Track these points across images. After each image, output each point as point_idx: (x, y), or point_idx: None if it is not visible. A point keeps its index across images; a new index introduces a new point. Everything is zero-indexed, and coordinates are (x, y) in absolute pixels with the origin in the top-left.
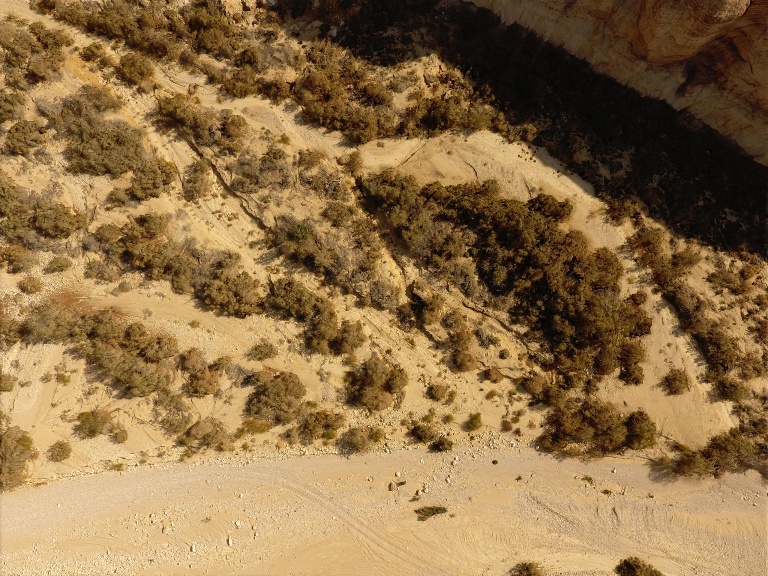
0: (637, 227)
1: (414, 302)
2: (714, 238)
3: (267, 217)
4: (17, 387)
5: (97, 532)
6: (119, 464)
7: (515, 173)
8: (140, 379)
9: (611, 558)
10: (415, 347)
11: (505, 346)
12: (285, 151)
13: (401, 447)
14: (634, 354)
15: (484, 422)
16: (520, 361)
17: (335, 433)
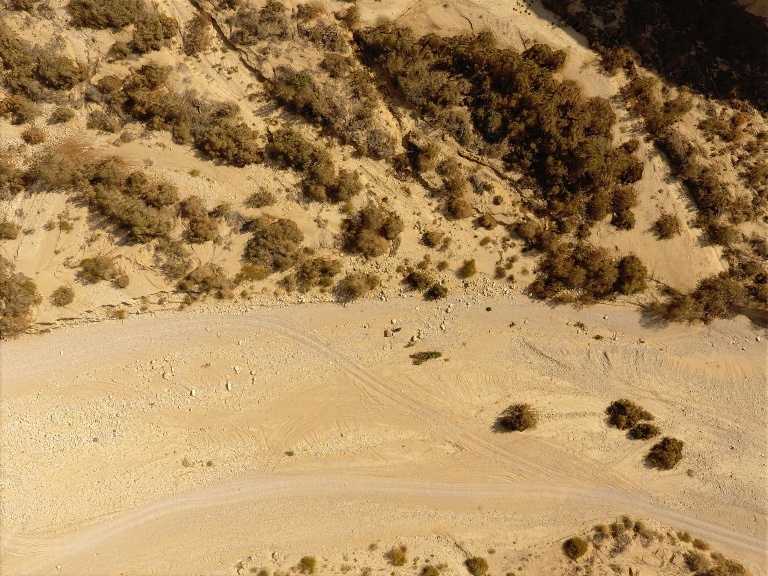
0: (630, 77)
1: (410, 151)
2: (706, 86)
3: (266, 68)
4: (21, 235)
5: (99, 378)
6: (121, 310)
7: (510, 25)
8: (141, 219)
9: (602, 400)
10: (411, 195)
11: (499, 193)
12: (284, 4)
13: (397, 295)
14: (626, 199)
15: (478, 269)
16: (514, 207)
17: (332, 280)
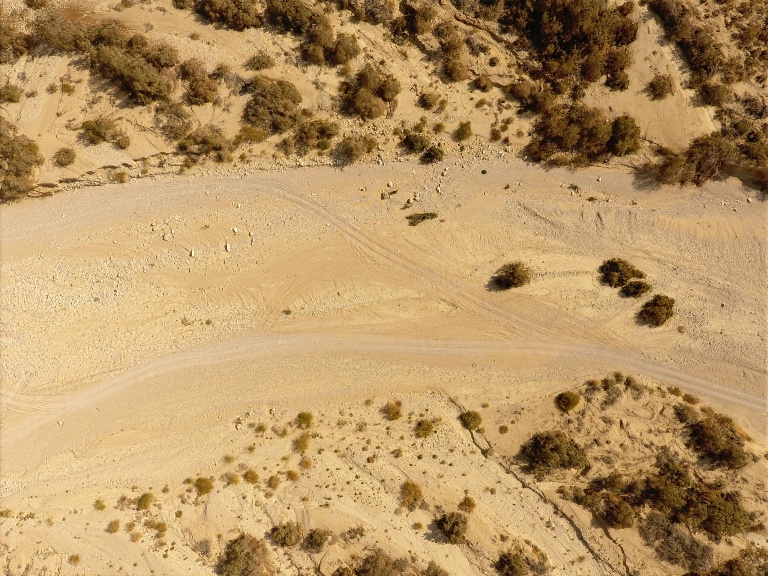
0: None
1: (407, 14)
2: None
3: None
4: (24, 98)
5: (100, 240)
6: (122, 172)
7: None
8: (142, 75)
9: (595, 259)
10: (408, 59)
11: (495, 55)
12: None
13: (393, 159)
14: (620, 60)
15: (474, 131)
16: (509, 69)
17: (330, 142)
